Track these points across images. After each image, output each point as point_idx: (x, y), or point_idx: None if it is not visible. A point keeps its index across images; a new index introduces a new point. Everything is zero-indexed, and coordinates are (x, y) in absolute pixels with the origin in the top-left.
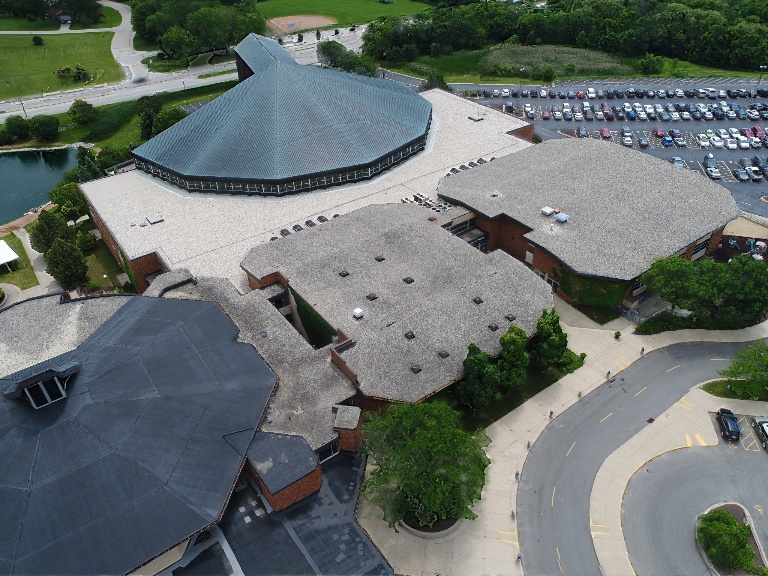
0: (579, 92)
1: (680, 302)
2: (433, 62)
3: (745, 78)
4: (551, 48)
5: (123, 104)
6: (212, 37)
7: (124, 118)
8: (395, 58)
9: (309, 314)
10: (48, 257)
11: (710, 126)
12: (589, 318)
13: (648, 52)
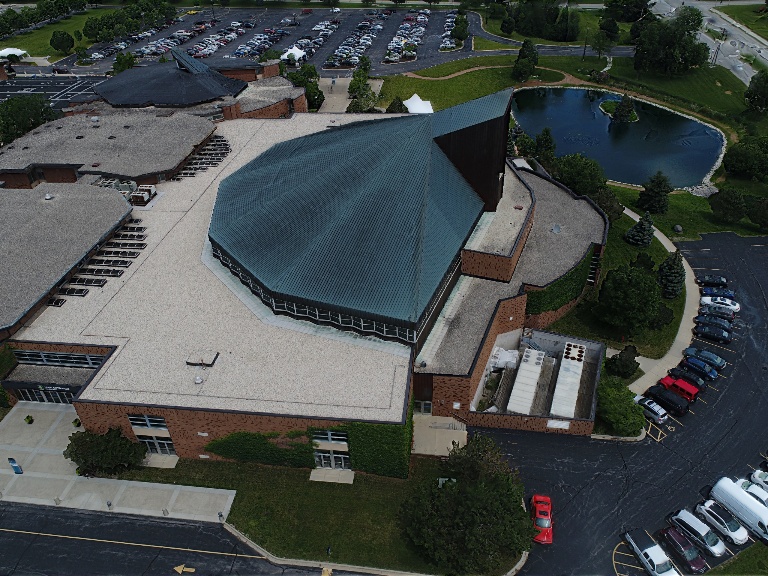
0: None
1: None
2: None
3: None
4: None
5: None
6: None
7: None
8: None
9: None
10: None
11: None
12: None
13: None
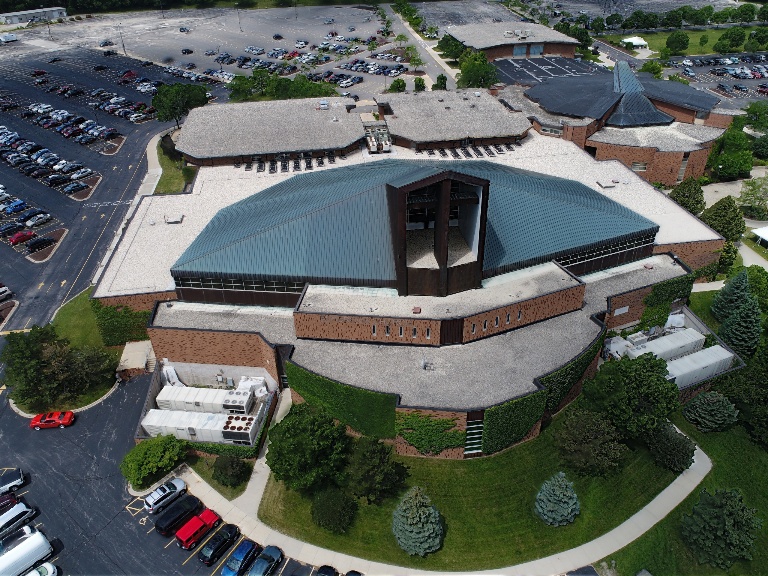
0: None
1: None
2: None
3: None
4: None
5: None
6: None
7: None
8: None
9: None
10: None
11: None
12: None
13: None
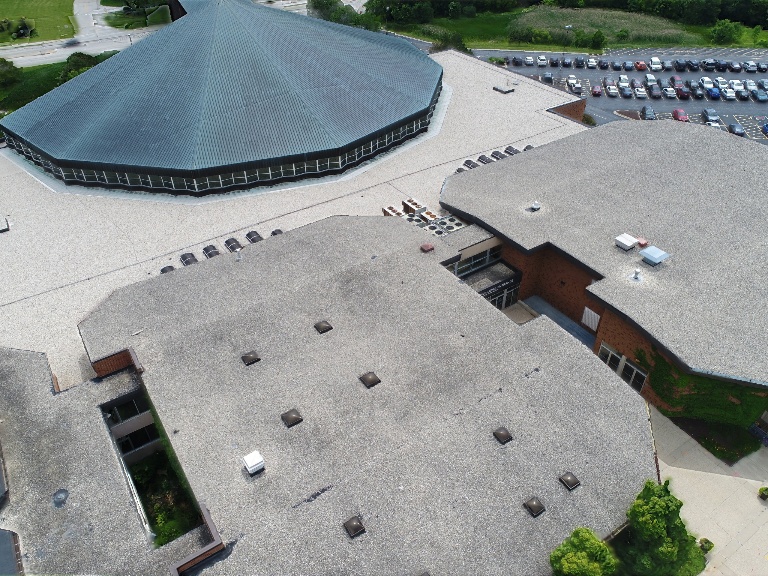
0: (639, 62)
1: None
2: (451, 25)
3: None
4: (597, 11)
5: (59, 64)
6: None
7: (54, 81)
8: (404, 19)
9: (165, 449)
10: None
11: None
12: (704, 448)
13: (719, 19)
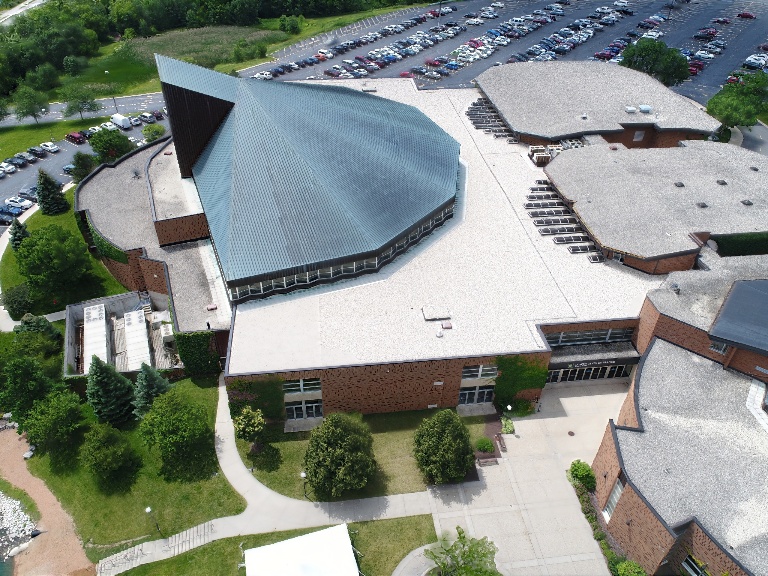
0: (320, 55)
1: (751, 122)
2: (90, 78)
3: (380, 15)
4: (181, 33)
5: None
6: None
7: None
8: (39, 87)
9: (756, 241)
10: (453, 450)
11: (443, 49)
12: None
13: (258, 17)
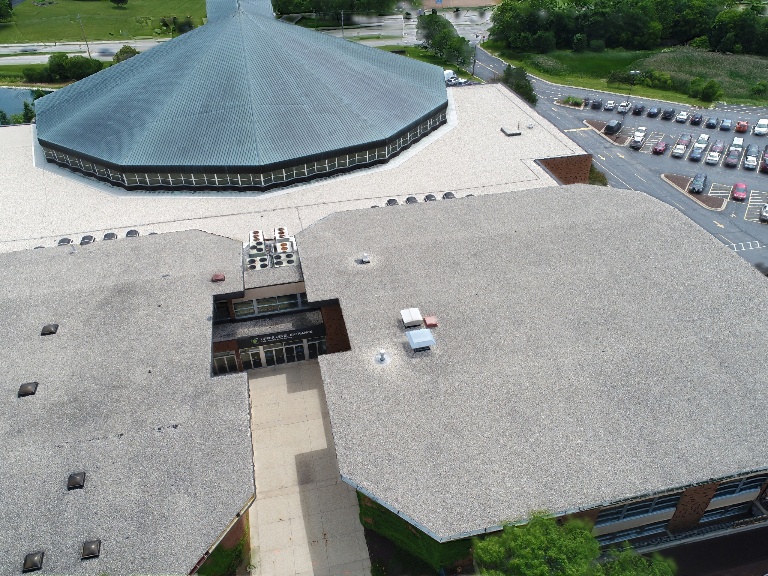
0: (740, 122)
1: None
2: (569, 58)
3: None
4: (751, 59)
5: None
6: (324, 0)
7: None
8: (521, 47)
9: None
10: None
11: None
12: (371, 575)
13: None
